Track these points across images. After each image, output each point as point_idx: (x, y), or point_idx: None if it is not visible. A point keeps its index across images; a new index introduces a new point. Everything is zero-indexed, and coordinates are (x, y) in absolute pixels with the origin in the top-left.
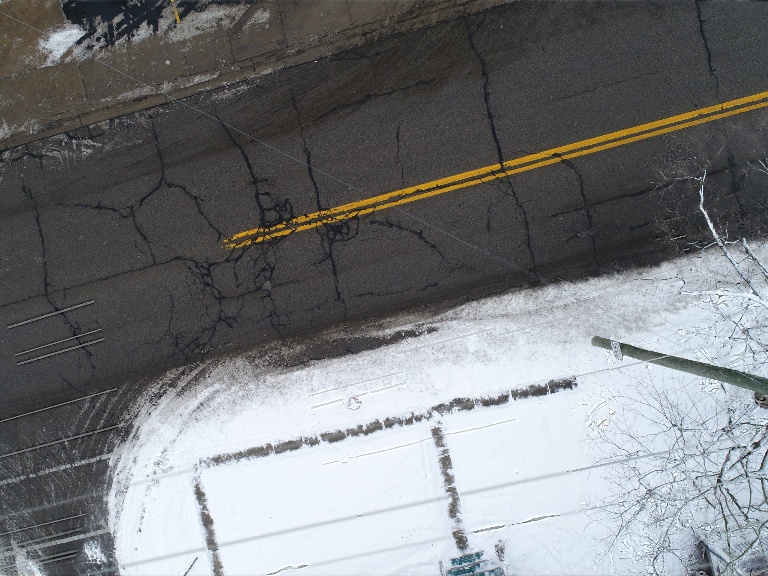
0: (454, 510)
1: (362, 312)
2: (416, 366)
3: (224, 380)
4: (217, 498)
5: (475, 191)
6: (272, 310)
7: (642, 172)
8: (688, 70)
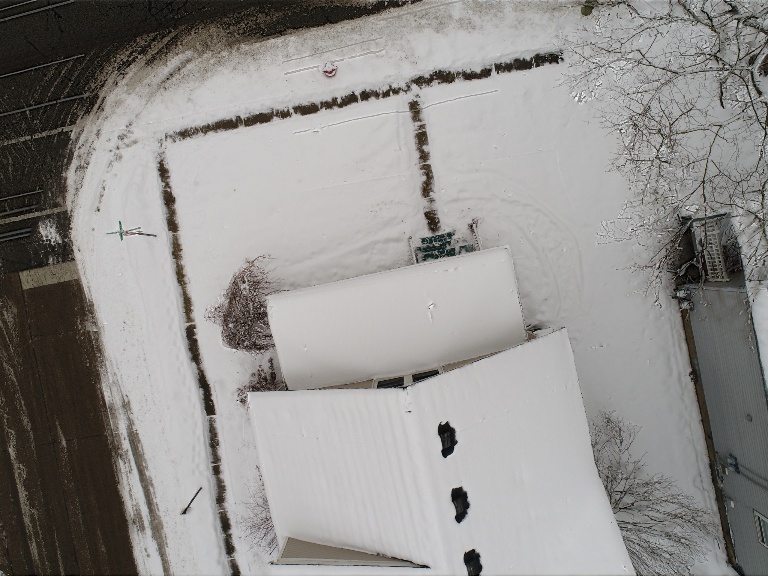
0: (427, 189)
1: None
2: (397, 32)
3: (196, 48)
4: (181, 171)
5: None
6: None
7: None
8: None
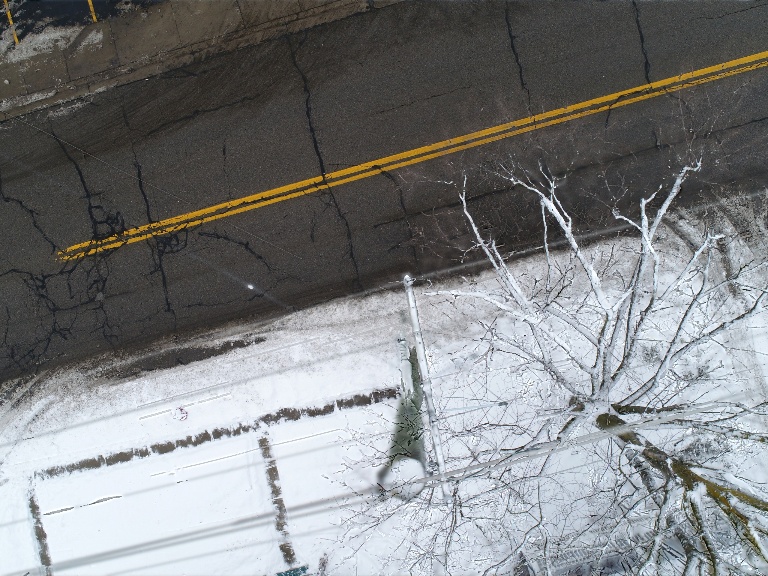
0: (281, 522)
1: (192, 323)
2: (241, 376)
3: (58, 391)
4: (48, 511)
5: (299, 203)
6: (104, 321)
7: (459, 183)
8: (501, 84)
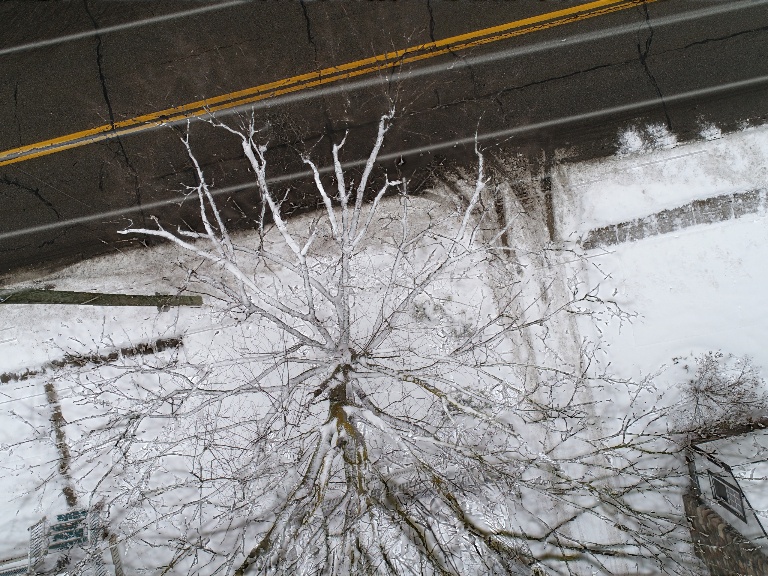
0: (64, 466)
1: None
2: (27, 322)
3: None
4: None
5: (88, 151)
6: None
7: None
8: (288, 37)
